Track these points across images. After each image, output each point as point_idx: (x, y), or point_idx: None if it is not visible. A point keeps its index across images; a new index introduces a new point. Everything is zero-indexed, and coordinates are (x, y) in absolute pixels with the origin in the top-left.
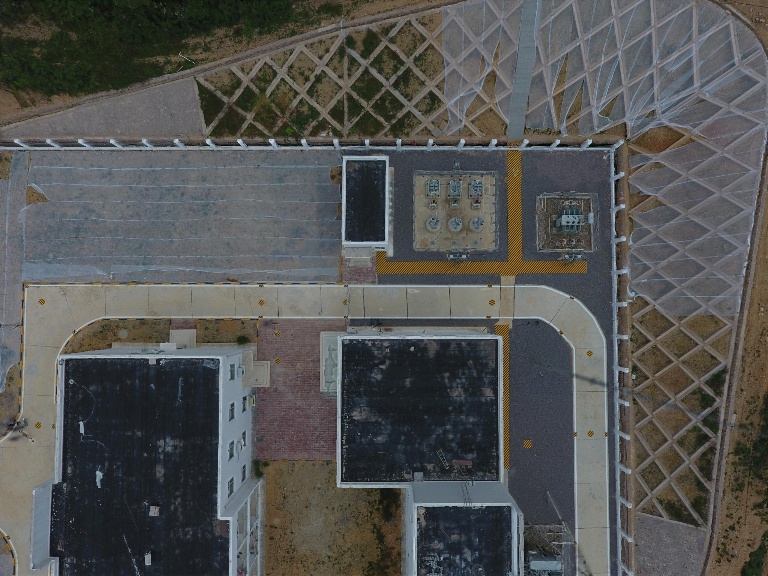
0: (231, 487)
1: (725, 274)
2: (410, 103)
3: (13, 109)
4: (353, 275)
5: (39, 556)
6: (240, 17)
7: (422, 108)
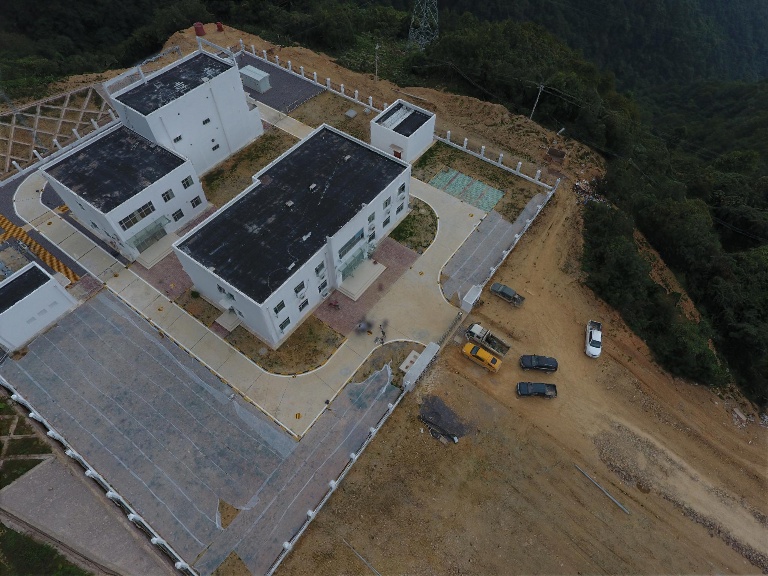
0: None
1: None
2: None
3: None
4: None
5: None
6: None
7: None
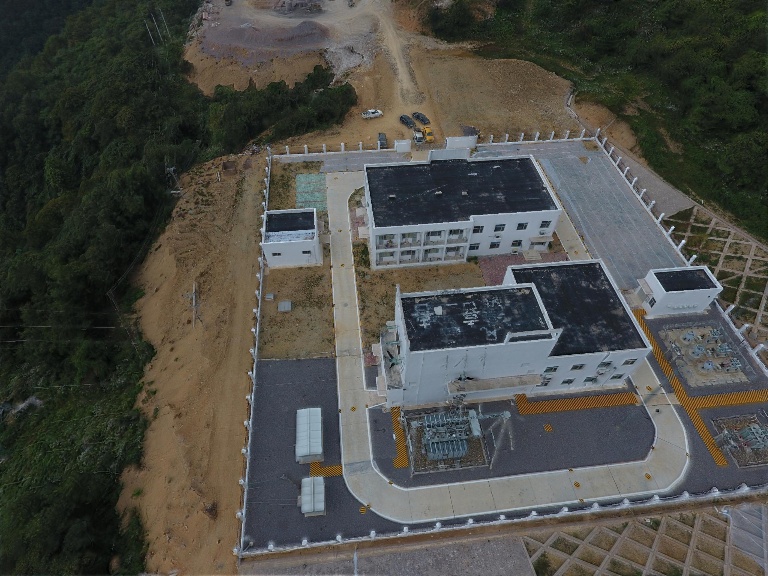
0: (476, 232)
1: None
2: (763, 311)
3: (627, 147)
4: None
5: (434, 154)
6: (747, 219)
7: (765, 321)
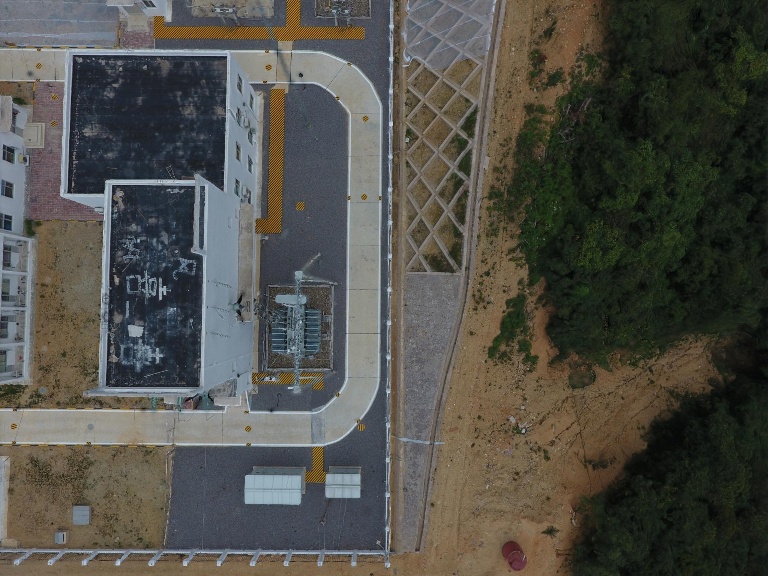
0: None
1: (478, 15)
2: None
3: None
4: (131, 40)
5: None
6: None
7: None
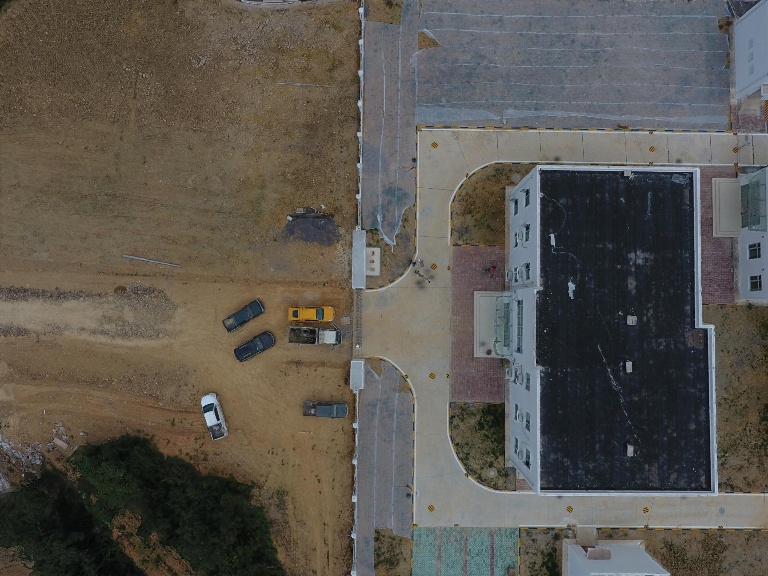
0: None
1: None
2: None
3: None
4: (742, 123)
5: None
6: None
7: None
